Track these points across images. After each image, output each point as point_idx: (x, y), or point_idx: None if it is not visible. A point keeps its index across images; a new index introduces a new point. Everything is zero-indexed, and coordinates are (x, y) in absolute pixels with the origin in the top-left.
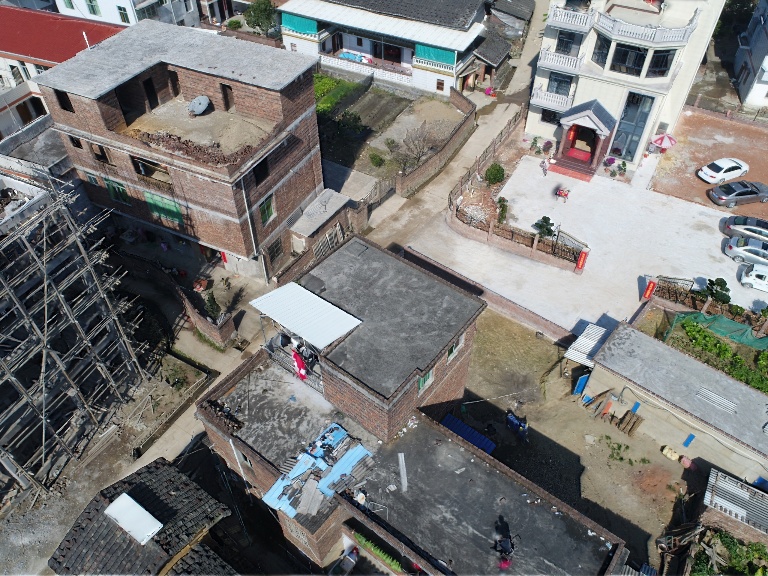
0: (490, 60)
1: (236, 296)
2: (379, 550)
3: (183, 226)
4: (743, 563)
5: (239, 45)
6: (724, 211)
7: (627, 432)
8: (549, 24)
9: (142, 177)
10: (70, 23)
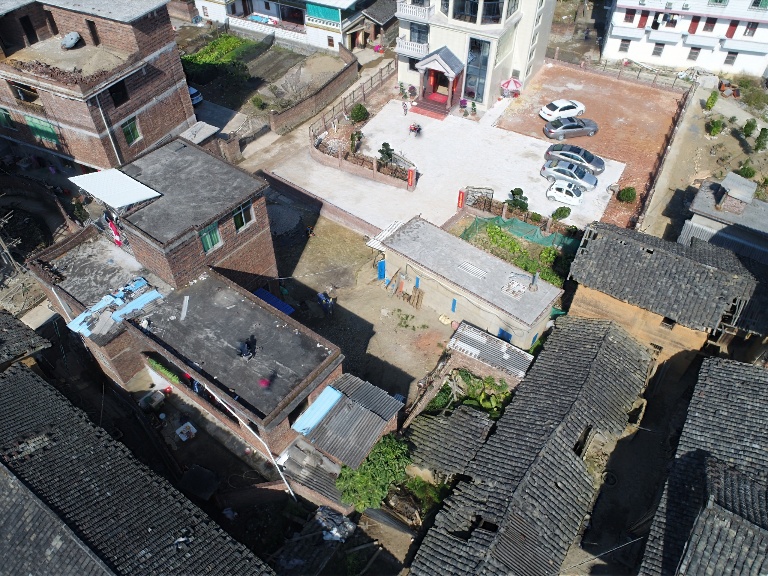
0: (377, 19)
1: None
2: (165, 369)
3: (60, 146)
4: (477, 393)
5: None
6: (553, 143)
7: (415, 306)
8: None
9: (20, 101)
10: None
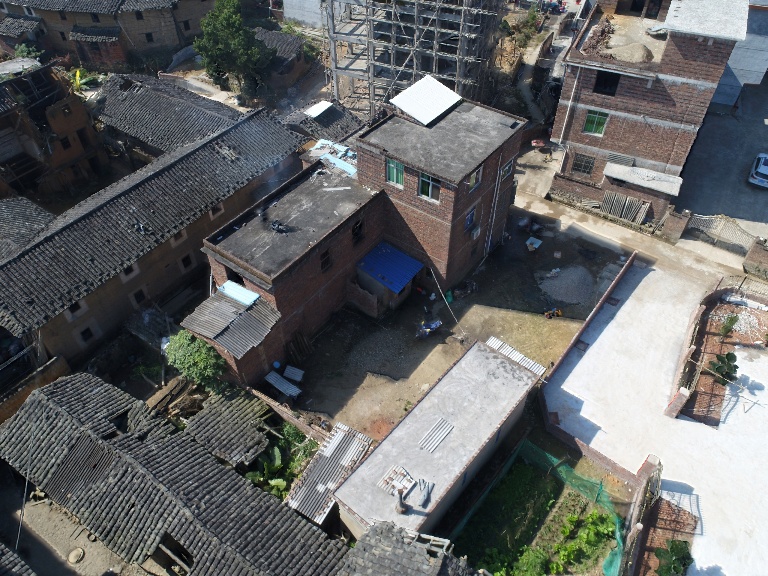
0: None
1: (538, 166)
2: None
3: None
4: None
5: (735, 5)
6: None
7: None
8: None
9: None
10: None
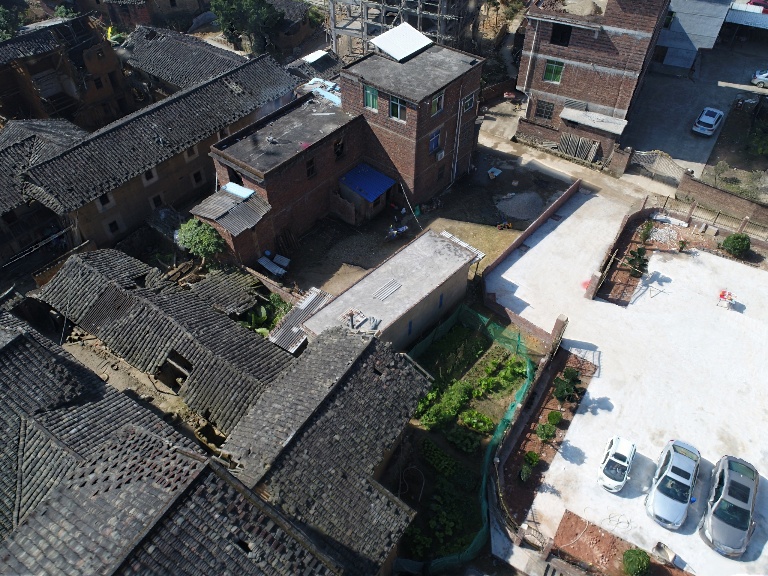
0: None
1: (508, 114)
2: None
3: None
4: None
5: None
6: None
7: None
8: None
9: None
10: None
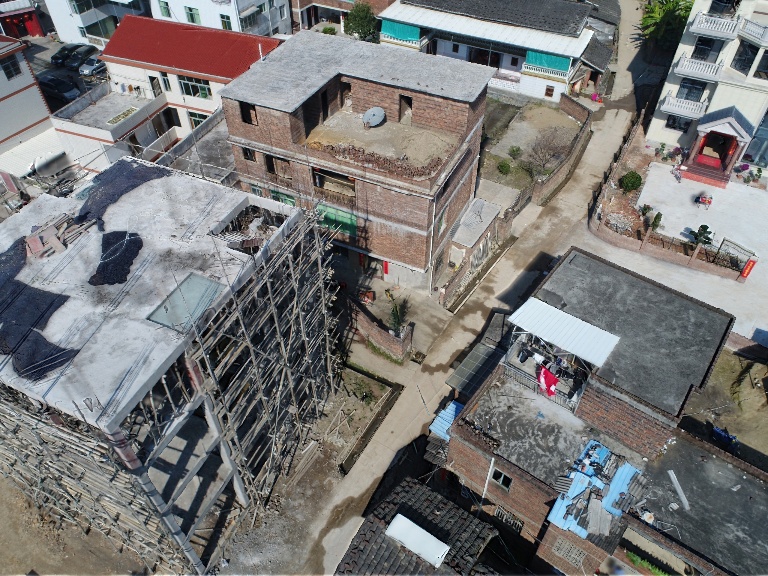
0: (598, 66)
1: (402, 308)
2: (658, 569)
3: (355, 238)
4: None
5: (411, 56)
6: None
7: None
8: (693, 31)
9: (320, 190)
10: (212, 34)
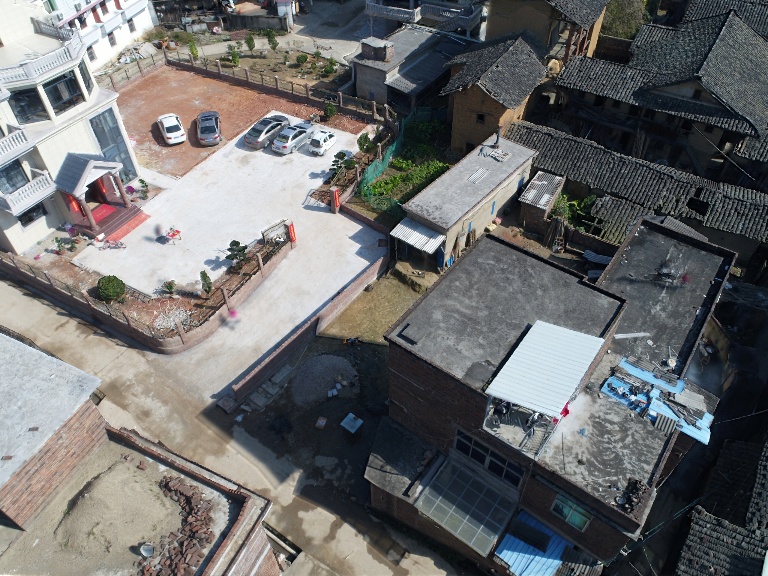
0: None
1: None
2: None
3: None
4: None
5: None
6: (226, 143)
7: None
8: None
9: None
10: None
